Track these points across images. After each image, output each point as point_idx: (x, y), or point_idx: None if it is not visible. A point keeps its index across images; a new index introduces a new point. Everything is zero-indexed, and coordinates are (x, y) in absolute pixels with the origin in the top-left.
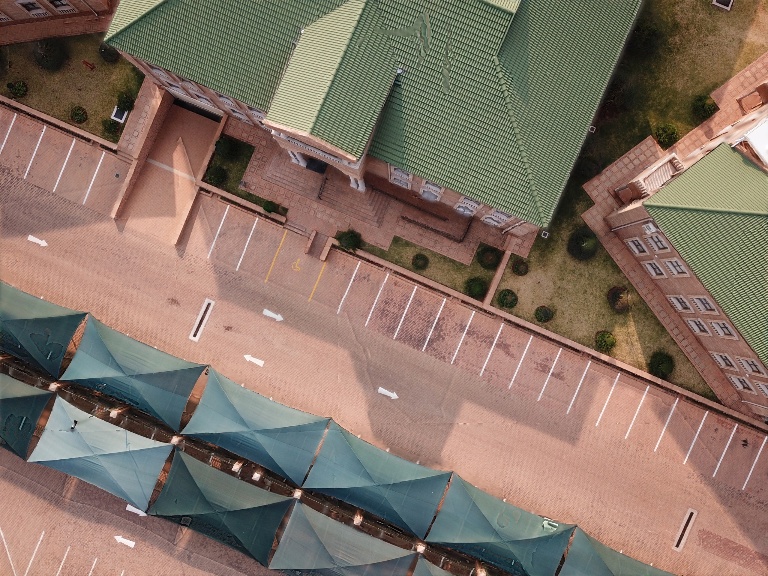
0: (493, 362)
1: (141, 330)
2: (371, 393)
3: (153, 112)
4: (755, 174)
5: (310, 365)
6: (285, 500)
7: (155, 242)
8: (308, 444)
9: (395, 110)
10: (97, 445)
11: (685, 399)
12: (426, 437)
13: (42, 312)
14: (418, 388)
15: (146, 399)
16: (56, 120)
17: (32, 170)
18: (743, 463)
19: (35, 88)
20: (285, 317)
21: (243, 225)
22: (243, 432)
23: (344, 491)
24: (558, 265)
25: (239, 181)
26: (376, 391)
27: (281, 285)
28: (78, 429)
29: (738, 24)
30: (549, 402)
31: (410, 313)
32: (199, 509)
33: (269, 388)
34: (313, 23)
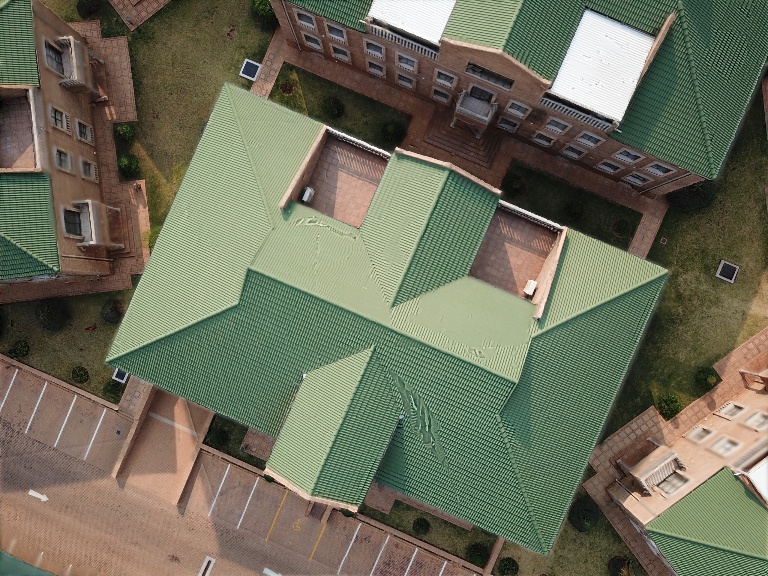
0: None
1: None
2: None
3: None
4: (757, 510)
5: None
6: None
7: (156, 499)
8: None
9: (397, 446)
10: None
11: None
12: None
13: None
14: None
15: None
16: (57, 380)
17: (33, 425)
18: None
19: (36, 347)
20: None
21: (244, 484)
22: None
23: None
24: (559, 534)
25: (240, 443)
26: None
27: (282, 544)
28: None
29: (741, 296)
30: None
31: (411, 575)
32: None
33: None
34: (315, 370)
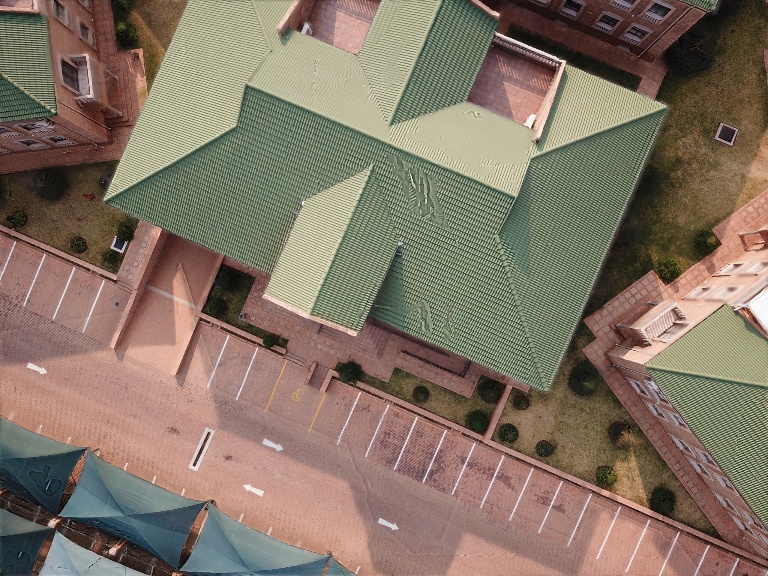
0: (494, 494)
1: (141, 459)
2: (371, 524)
3: (153, 243)
4: (757, 342)
5: (310, 495)
6: None
7: (155, 371)
8: None
9: (396, 278)
10: None
11: (686, 533)
12: (426, 568)
13: (41, 450)
14: (418, 519)
15: (145, 539)
16: (56, 250)
17: (32, 298)
18: None
19: (35, 218)
20: (285, 447)
21: (243, 355)
22: (243, 573)
23: None
24: (559, 399)
25: (239, 312)
26: (376, 522)
27: (281, 415)
28: (77, 567)
29: (741, 159)
30: (550, 534)
31: (410, 444)
32: None
33: (269, 518)
34: (314, 196)
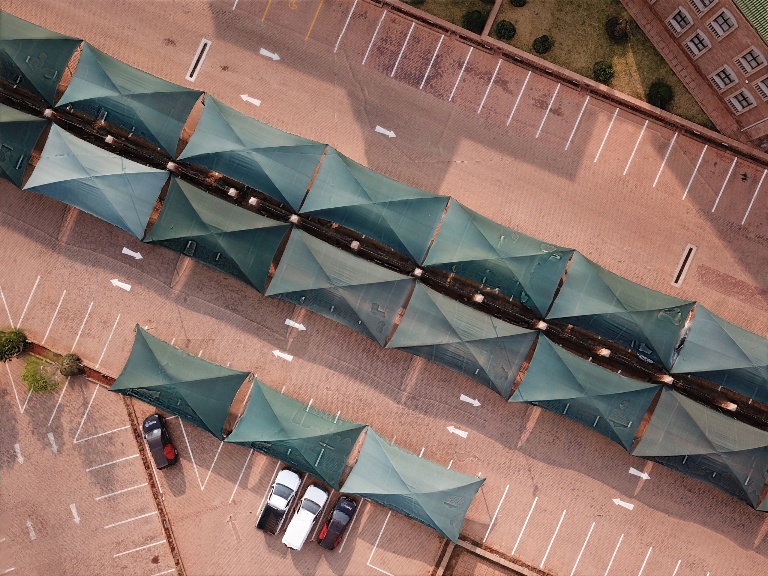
0: (491, 99)
1: None
2: (368, 132)
3: None
4: None
5: (307, 104)
6: (282, 225)
7: None
8: (305, 167)
9: None
10: (93, 167)
11: (684, 132)
12: (424, 175)
13: (37, 34)
14: (416, 126)
15: (142, 119)
16: None
17: None
18: (742, 197)
19: None
20: (282, 56)
21: None
22: (239, 151)
23: (341, 211)
24: None
25: None
26: (373, 130)
27: (278, 24)
28: (73, 151)
29: None
30: (547, 139)
31: (408, 50)
32: (195, 231)
33: None
34: None
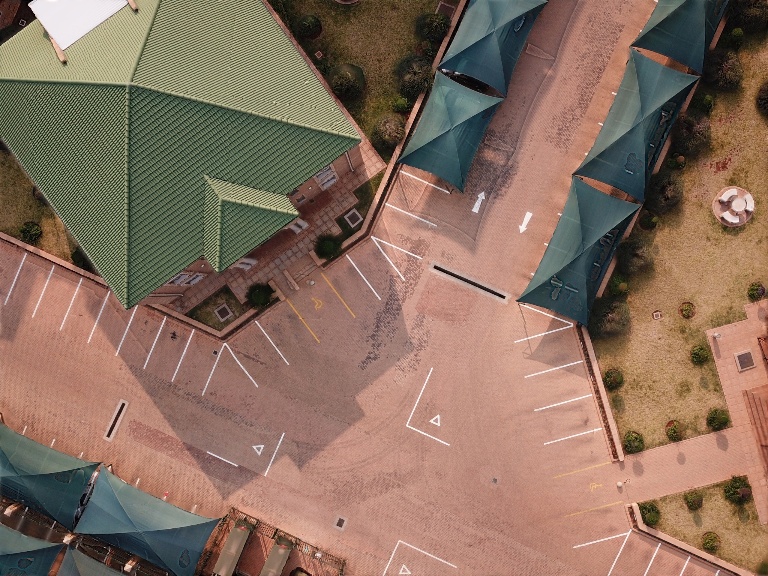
0: None
1: None
2: None
3: None
4: (45, 45)
5: None
6: None
7: None
8: None
9: None
10: None
11: None
12: None
13: None
14: None
15: None
16: None
17: None
18: (172, 355)
19: None
20: None
21: None
22: None
23: None
24: None
25: None
26: None
27: None
28: None
29: None
30: None
31: None
32: None
33: None
34: None
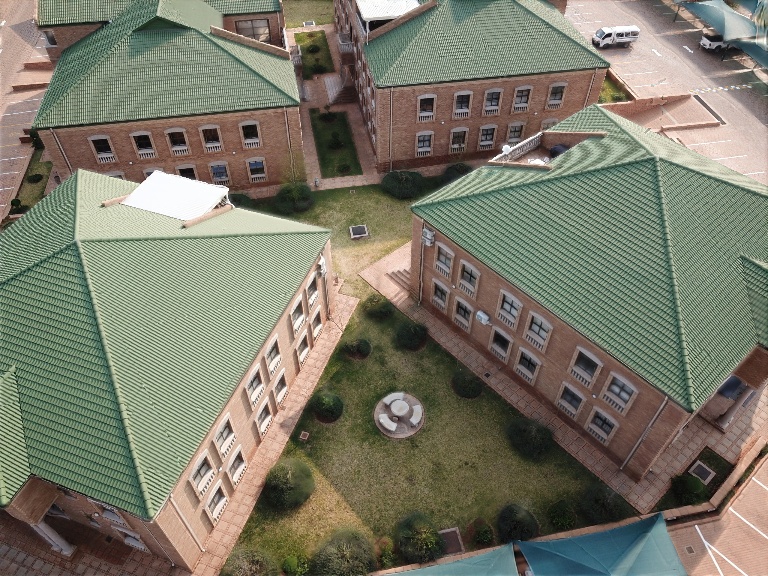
0: None
1: None
2: None
3: None
4: None
5: None
6: None
7: None
8: None
9: None
10: None
11: None
12: None
13: None
14: None
15: None
16: None
17: None
18: None
19: None
20: None
21: None
22: None
23: None
24: None
25: None
26: None
27: None
28: None
29: (346, 249)
30: None
31: None
32: None
33: None
34: None
